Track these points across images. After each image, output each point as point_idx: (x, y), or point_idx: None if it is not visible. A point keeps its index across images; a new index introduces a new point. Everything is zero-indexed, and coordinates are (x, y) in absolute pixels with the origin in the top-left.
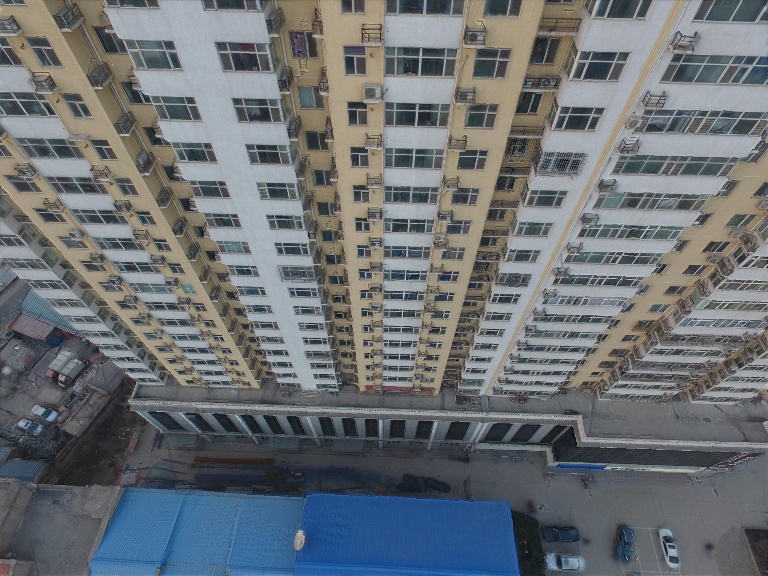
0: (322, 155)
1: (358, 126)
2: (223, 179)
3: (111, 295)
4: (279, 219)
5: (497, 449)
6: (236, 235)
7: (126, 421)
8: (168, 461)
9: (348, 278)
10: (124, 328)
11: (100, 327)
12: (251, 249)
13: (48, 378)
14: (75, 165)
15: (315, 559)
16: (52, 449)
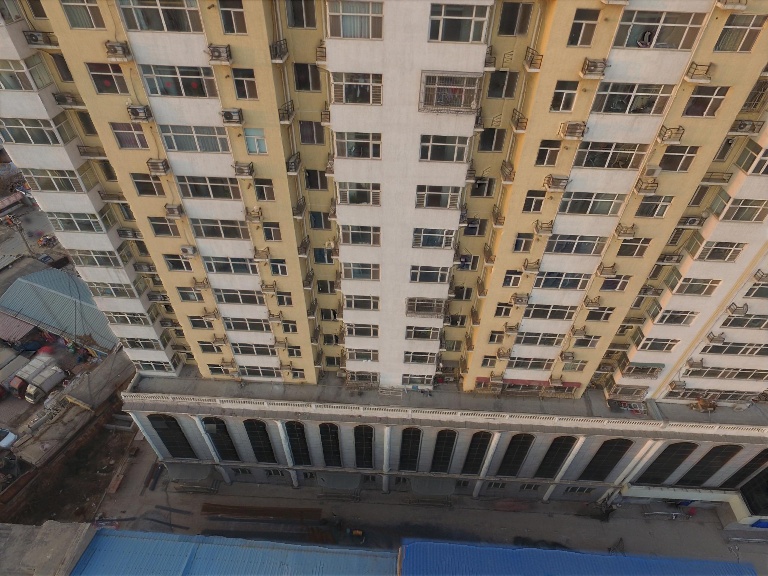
0: None
1: None
2: None
3: (127, 158)
4: None
5: (654, 497)
6: None
7: (110, 450)
8: (164, 509)
9: (531, 107)
10: (134, 258)
11: (99, 241)
12: (385, 25)
13: (13, 390)
14: None
15: None
16: None
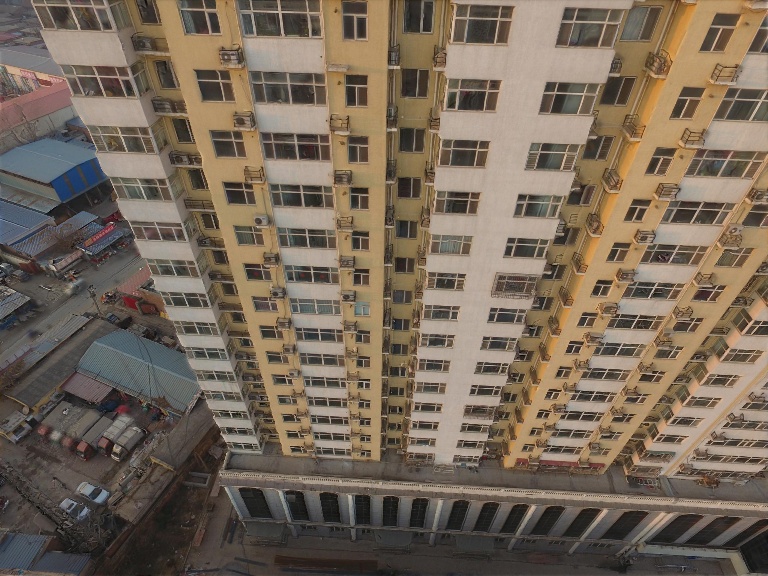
0: (614, 112)
1: (710, 53)
2: (490, 137)
3: (259, 317)
4: (531, 202)
5: (666, 554)
6: (464, 226)
7: (191, 505)
8: (242, 561)
9: (577, 294)
10: (243, 371)
11: (222, 365)
12: (473, 248)
13: (100, 449)
14: (308, 115)
15: None
16: (101, 539)
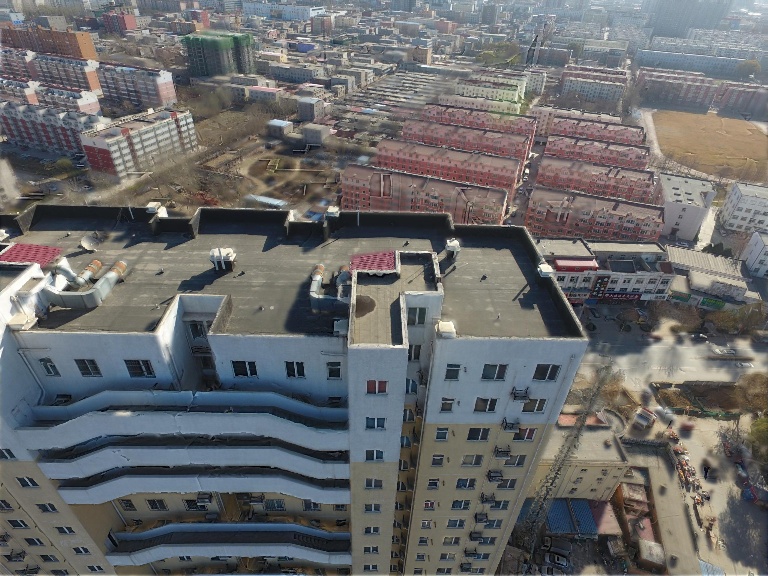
0: None
1: None
2: None
3: None
4: None
5: None
6: None
7: None
8: None
9: None
10: None
11: None
12: None
13: None
14: None
15: None
16: (519, 534)
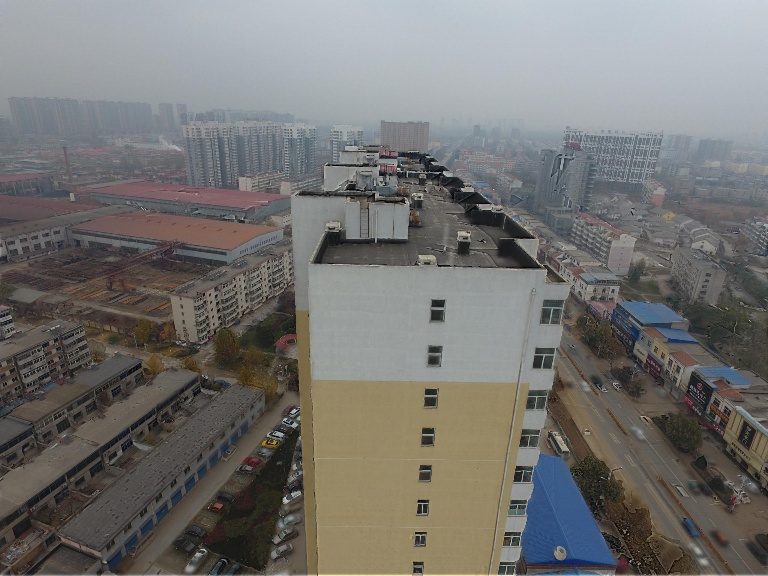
0: None
1: None
2: None
3: None
4: None
5: None
6: None
7: None
8: None
9: None
10: None
11: None
12: None
13: None
14: None
15: (565, 547)
16: None
